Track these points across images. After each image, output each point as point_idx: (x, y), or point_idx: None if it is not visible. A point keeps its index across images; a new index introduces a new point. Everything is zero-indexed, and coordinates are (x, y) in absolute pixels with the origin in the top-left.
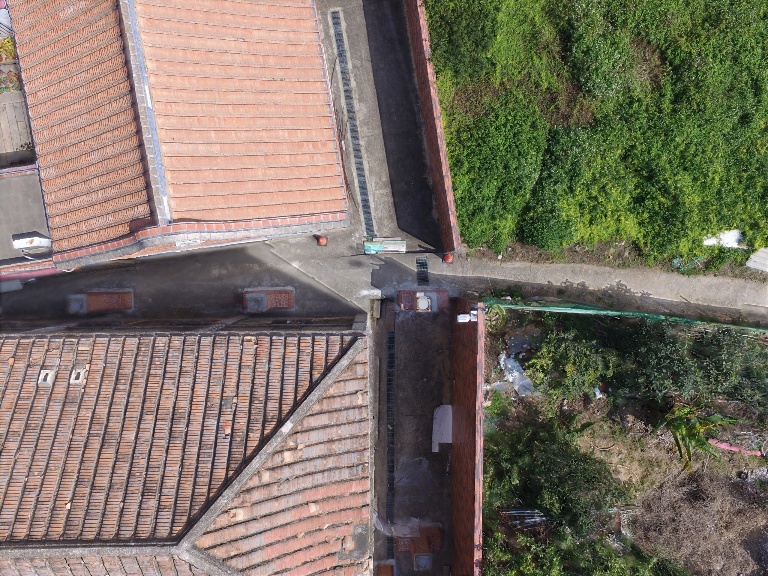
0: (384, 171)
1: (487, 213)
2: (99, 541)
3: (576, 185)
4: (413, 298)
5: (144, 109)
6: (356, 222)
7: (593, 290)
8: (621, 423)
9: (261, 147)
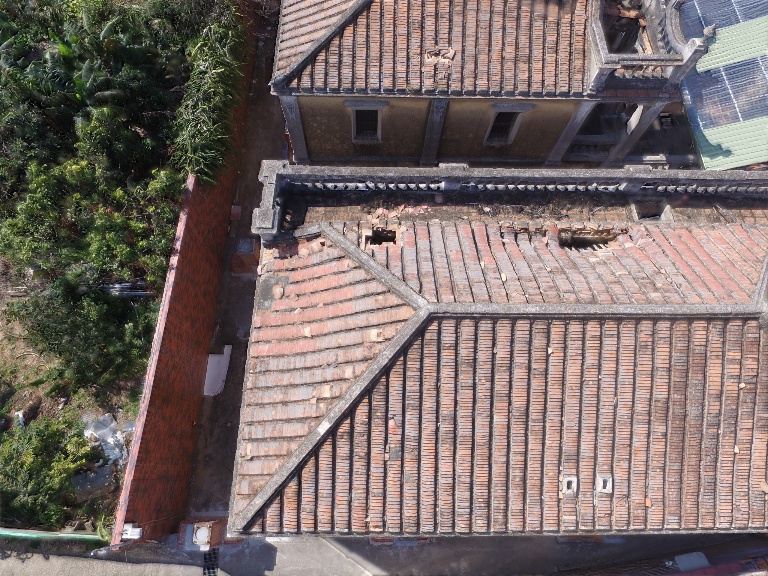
0: None
1: None
2: (511, 318)
3: None
4: (221, 536)
5: None
6: None
7: None
8: (2, 382)
9: None
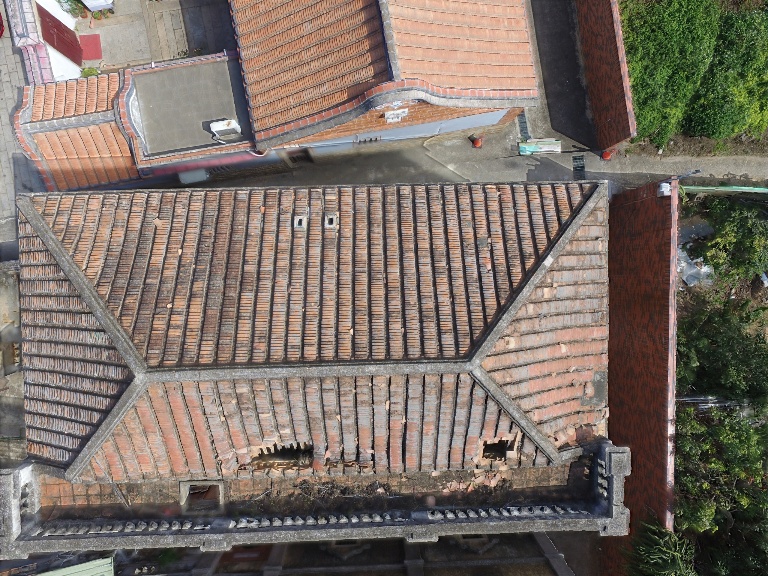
0: (537, 72)
1: (659, 100)
2: (391, 360)
3: (748, 70)
4: None
5: None
6: (510, 124)
7: (756, 181)
8: None
9: (465, 19)
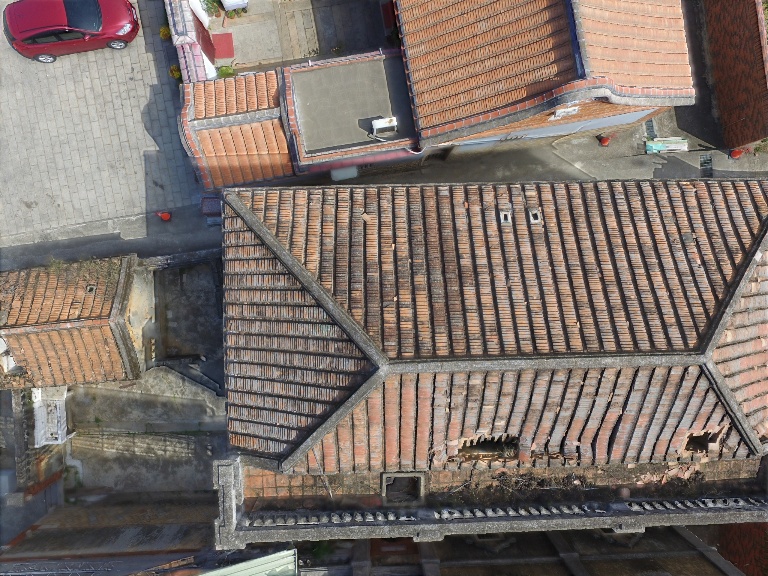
0: None
1: None
2: (625, 352)
3: None
4: None
5: None
6: None
7: None
8: None
9: (634, 18)
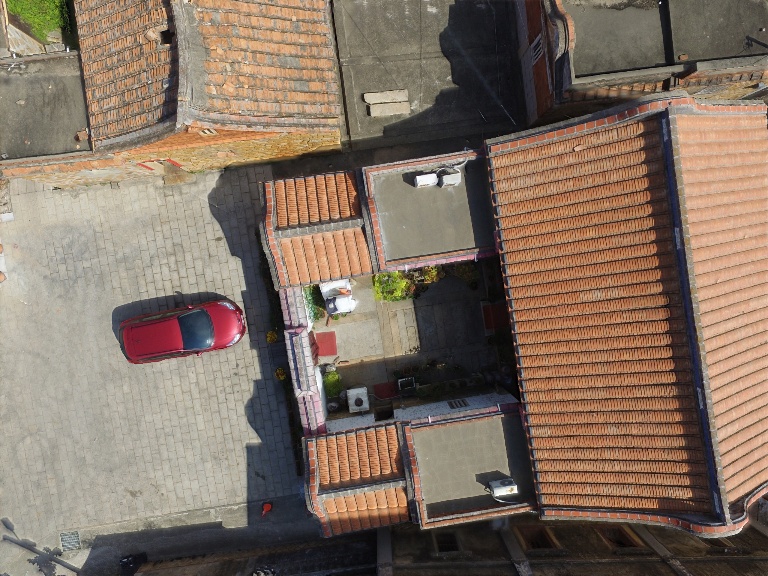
0: None
1: None
2: None
3: None
4: None
5: (713, 414)
6: None
7: None
8: None
9: (759, 414)
